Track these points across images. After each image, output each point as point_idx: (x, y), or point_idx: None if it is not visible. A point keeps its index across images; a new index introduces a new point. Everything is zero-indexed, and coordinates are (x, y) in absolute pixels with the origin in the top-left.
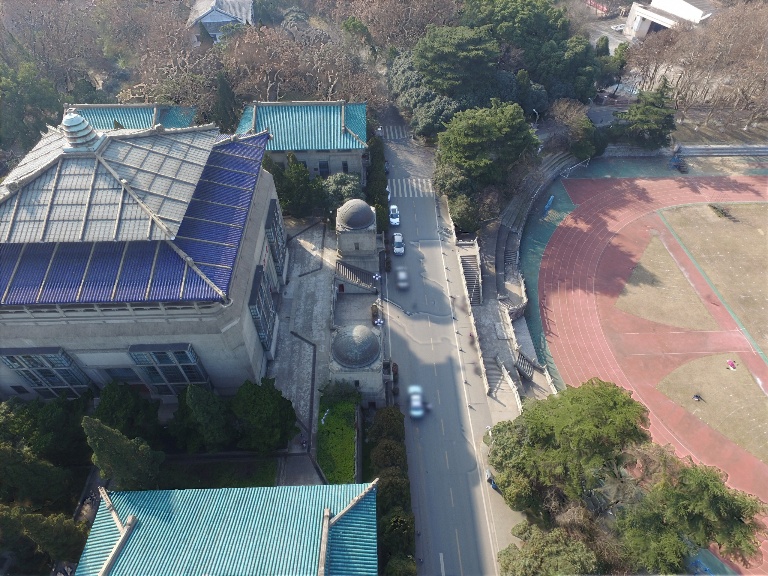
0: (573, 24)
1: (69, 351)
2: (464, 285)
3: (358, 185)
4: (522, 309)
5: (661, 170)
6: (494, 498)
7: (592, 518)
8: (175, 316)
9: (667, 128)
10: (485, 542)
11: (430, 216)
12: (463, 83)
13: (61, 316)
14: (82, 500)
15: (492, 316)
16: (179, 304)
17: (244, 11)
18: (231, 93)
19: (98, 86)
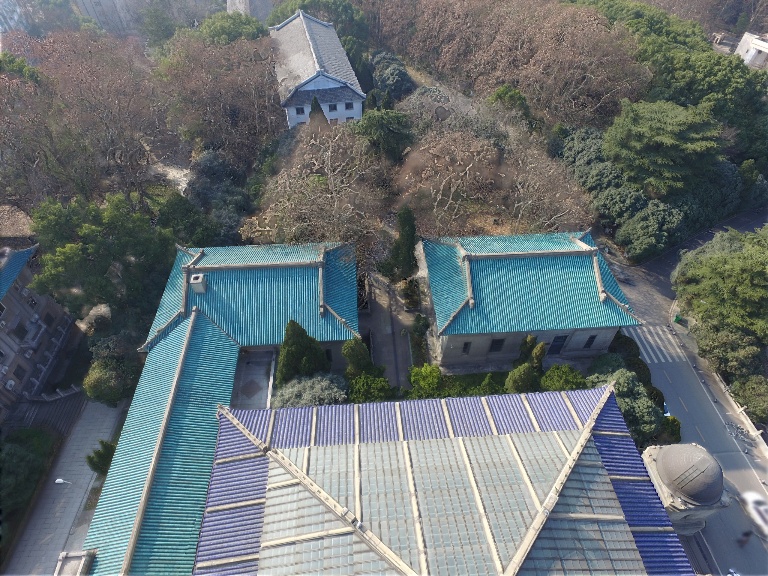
0: None
1: None
2: None
3: (646, 391)
4: None
5: None
6: None
7: None
8: None
9: None
10: None
11: (703, 401)
12: None
13: None
14: None
15: None
16: None
17: (346, 69)
18: (414, 230)
19: (146, 153)
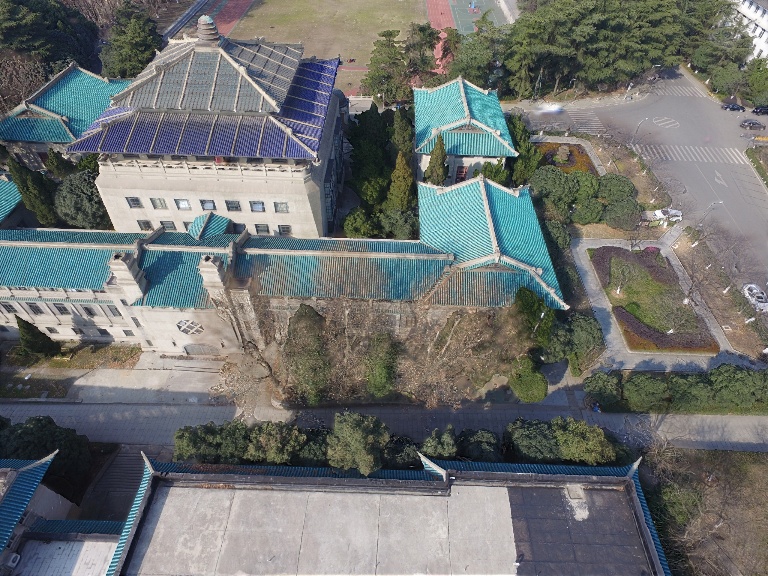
0: None
1: None
2: None
3: None
4: None
5: None
6: None
7: None
8: None
9: None
10: None
11: None
12: None
13: None
14: None
15: None
16: None
17: None
18: None
19: None
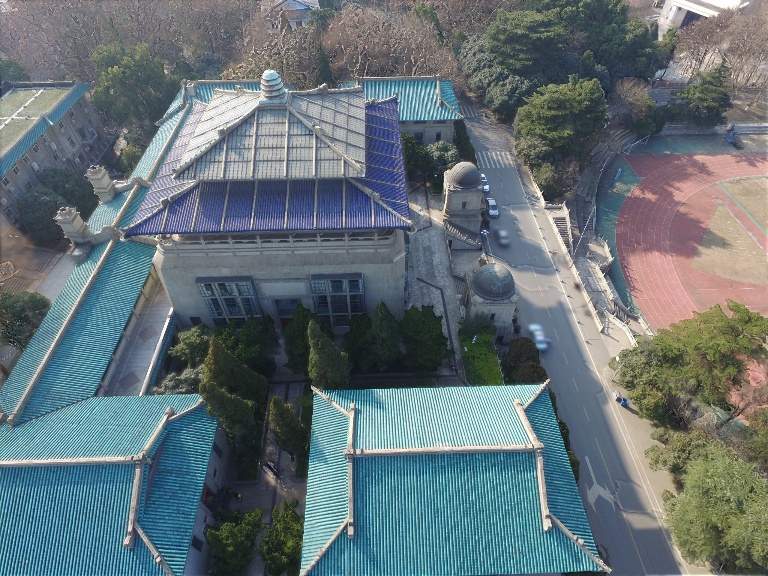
0: (630, 9)
1: (256, 280)
2: (561, 242)
3: None
4: (607, 267)
5: (717, 146)
6: (625, 414)
7: (718, 427)
8: (355, 247)
9: (724, 106)
10: (623, 448)
11: (515, 184)
12: (533, 64)
13: (257, 247)
14: (268, 411)
15: (584, 272)
16: (361, 236)
17: (312, 0)
18: (330, 71)
19: None
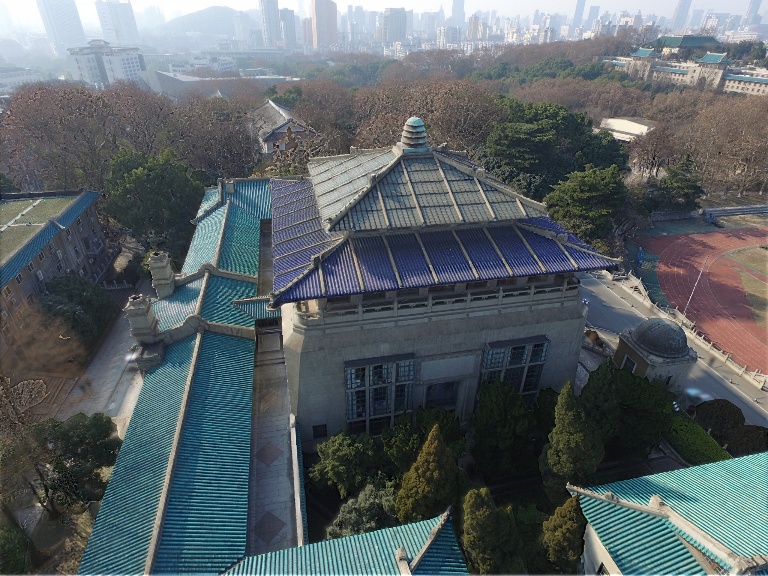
0: (593, 124)
1: (418, 359)
2: (653, 307)
3: None
4: None
5: (702, 227)
6: None
7: None
8: (540, 302)
9: (698, 193)
10: None
11: None
12: None
13: (425, 312)
14: None
15: None
16: (547, 287)
17: None
18: None
19: None
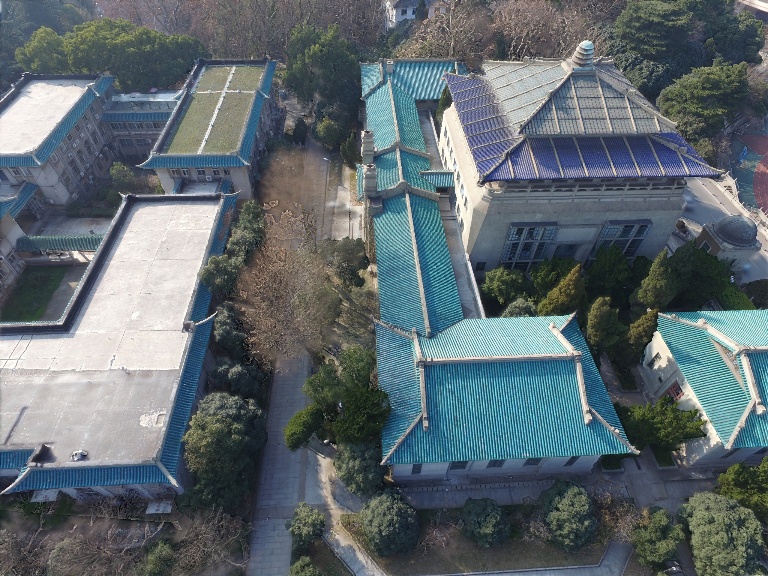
0: (735, 1)
1: (558, 226)
2: (739, 206)
3: None
4: None
5: None
6: None
7: None
8: (653, 195)
9: None
10: None
11: None
12: None
13: (571, 195)
14: None
15: None
16: (661, 185)
17: None
18: None
19: None
